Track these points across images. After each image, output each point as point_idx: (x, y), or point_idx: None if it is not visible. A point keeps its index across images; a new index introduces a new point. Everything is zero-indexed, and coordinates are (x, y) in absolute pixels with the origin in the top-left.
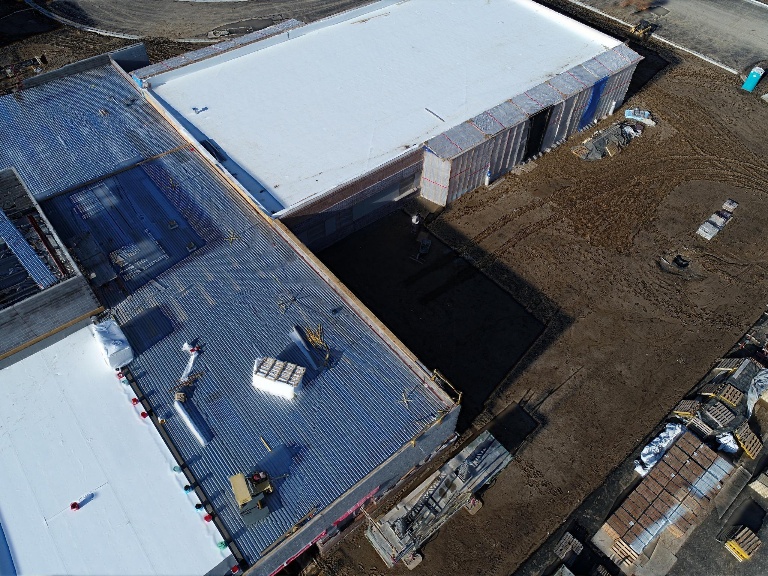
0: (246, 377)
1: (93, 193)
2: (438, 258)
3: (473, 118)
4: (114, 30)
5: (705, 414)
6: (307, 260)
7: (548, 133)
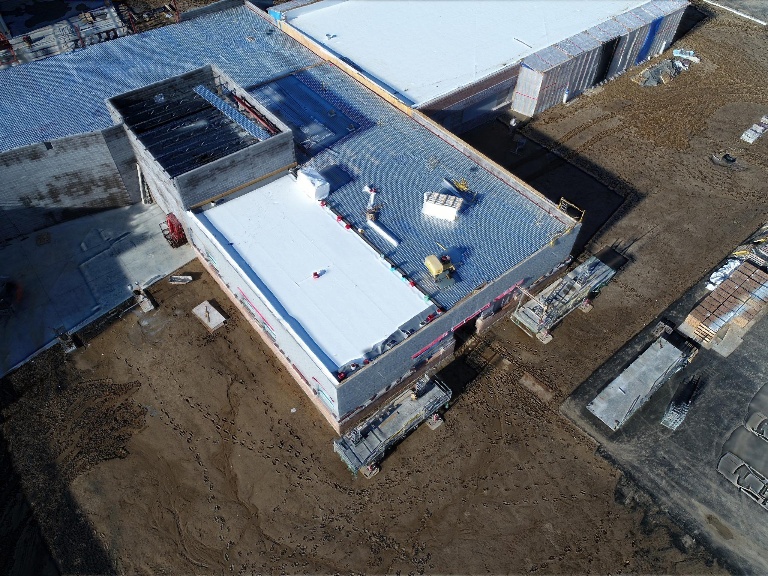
0: (415, 208)
1: (262, 92)
2: (532, 152)
3: (557, 43)
4: None
5: (758, 251)
6: (443, 137)
7: (613, 62)
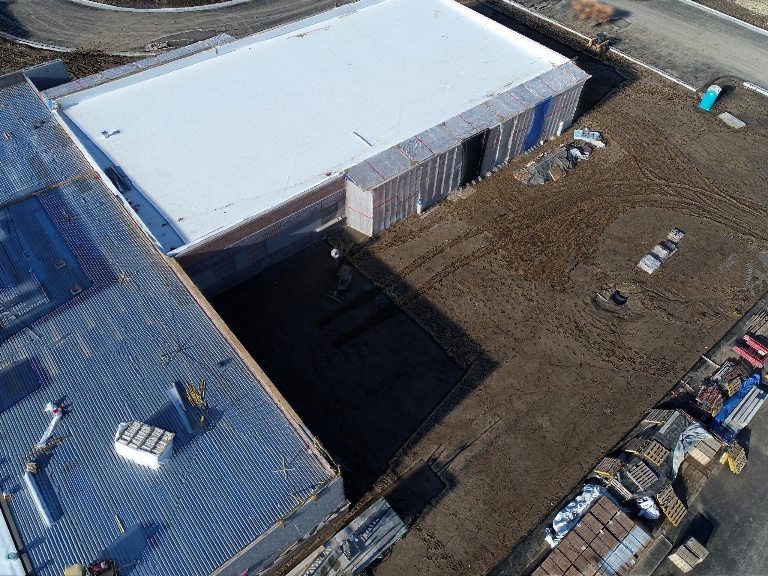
0: (111, 442)
1: None
2: (358, 295)
3: (400, 143)
4: (47, 42)
5: (625, 475)
6: (200, 304)
7: (487, 157)
